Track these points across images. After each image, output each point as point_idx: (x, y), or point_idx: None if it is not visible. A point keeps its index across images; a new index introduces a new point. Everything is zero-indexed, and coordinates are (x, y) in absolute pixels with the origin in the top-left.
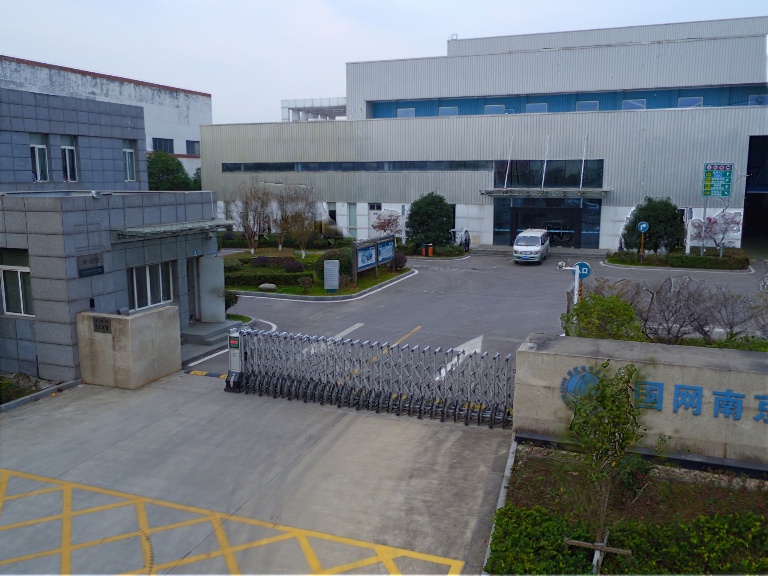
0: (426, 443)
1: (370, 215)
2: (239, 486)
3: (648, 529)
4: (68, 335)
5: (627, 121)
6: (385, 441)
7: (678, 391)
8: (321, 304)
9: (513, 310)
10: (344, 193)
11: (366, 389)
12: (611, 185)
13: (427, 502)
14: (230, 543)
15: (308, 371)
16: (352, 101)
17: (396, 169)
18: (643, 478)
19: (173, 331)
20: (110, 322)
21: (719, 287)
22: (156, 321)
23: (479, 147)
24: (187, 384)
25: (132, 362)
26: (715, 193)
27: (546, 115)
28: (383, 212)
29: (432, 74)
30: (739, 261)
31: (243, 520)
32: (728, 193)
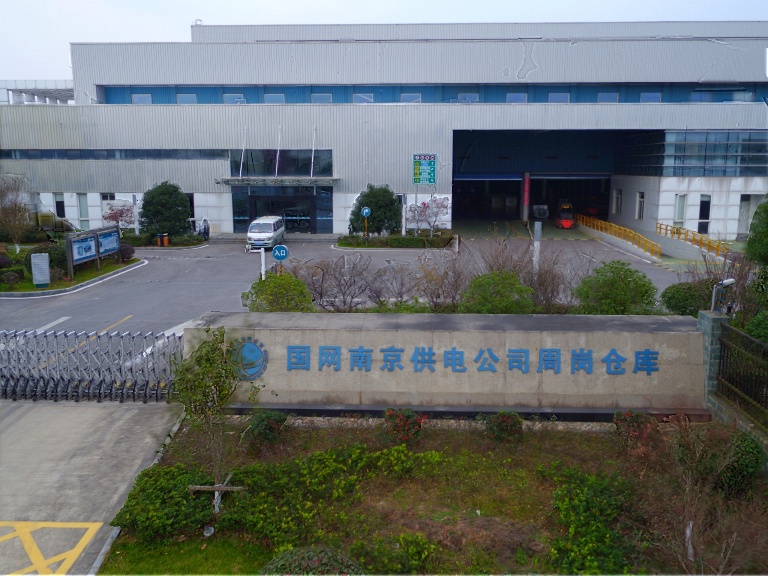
0: (98, 424)
1: (103, 206)
2: None
3: (268, 468)
4: None
5: (350, 114)
6: (56, 427)
7: (322, 352)
8: (28, 300)
9: (231, 294)
10: (72, 183)
11: (45, 379)
12: (340, 174)
13: (82, 476)
14: None
15: None
16: (80, 84)
17: (128, 157)
18: (278, 427)
19: None
20: None
21: (388, 262)
22: None
23: (213, 136)
24: None
25: None
26: (423, 180)
27: (277, 106)
28: (115, 202)
29: (166, 60)
30: (445, 240)
31: None
32: (434, 180)
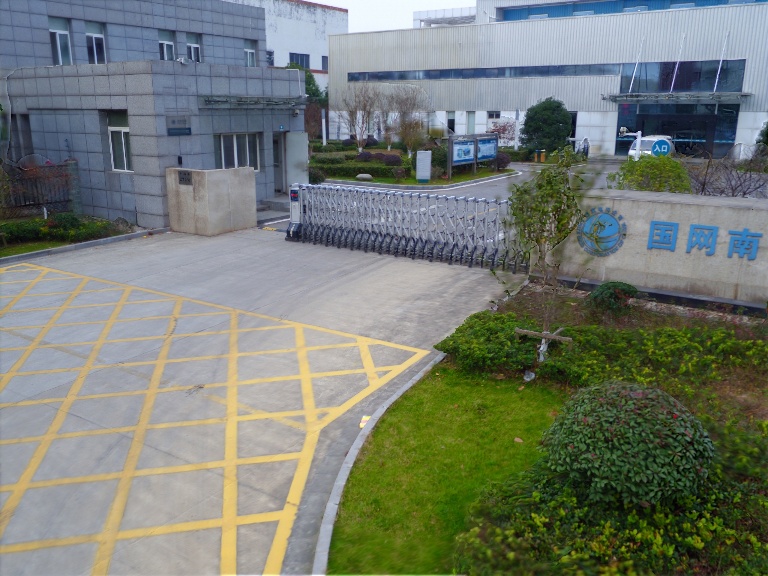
0: (445, 280)
1: (489, 124)
2: (265, 296)
3: (606, 331)
4: (158, 187)
5: None
6: (408, 277)
7: (693, 231)
8: None
9: None
10: (463, 101)
11: (407, 239)
12: (752, 88)
13: (421, 315)
14: (239, 327)
15: (356, 221)
16: None
17: (517, 75)
18: (626, 299)
19: (249, 189)
20: (191, 175)
21: None
22: (232, 177)
23: (606, 49)
24: (256, 235)
25: (208, 211)
26: None
27: (683, 11)
28: (500, 119)
29: None
30: None
31: (257, 315)
32: None
